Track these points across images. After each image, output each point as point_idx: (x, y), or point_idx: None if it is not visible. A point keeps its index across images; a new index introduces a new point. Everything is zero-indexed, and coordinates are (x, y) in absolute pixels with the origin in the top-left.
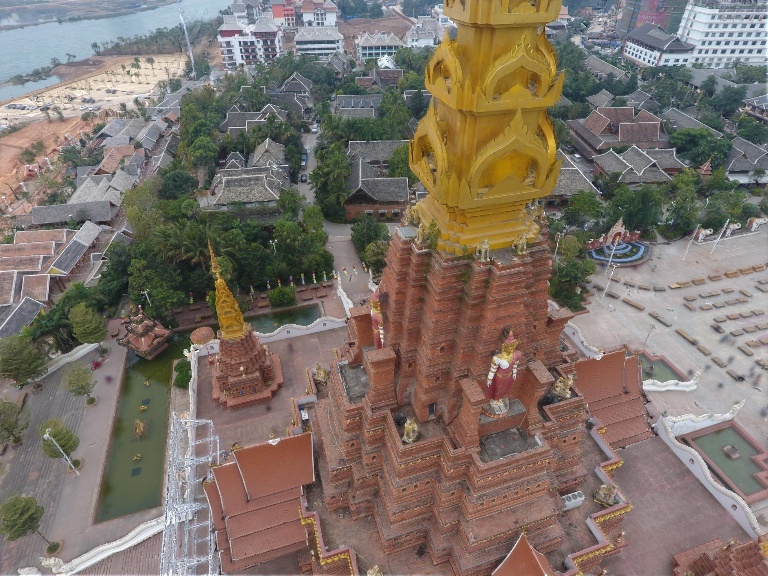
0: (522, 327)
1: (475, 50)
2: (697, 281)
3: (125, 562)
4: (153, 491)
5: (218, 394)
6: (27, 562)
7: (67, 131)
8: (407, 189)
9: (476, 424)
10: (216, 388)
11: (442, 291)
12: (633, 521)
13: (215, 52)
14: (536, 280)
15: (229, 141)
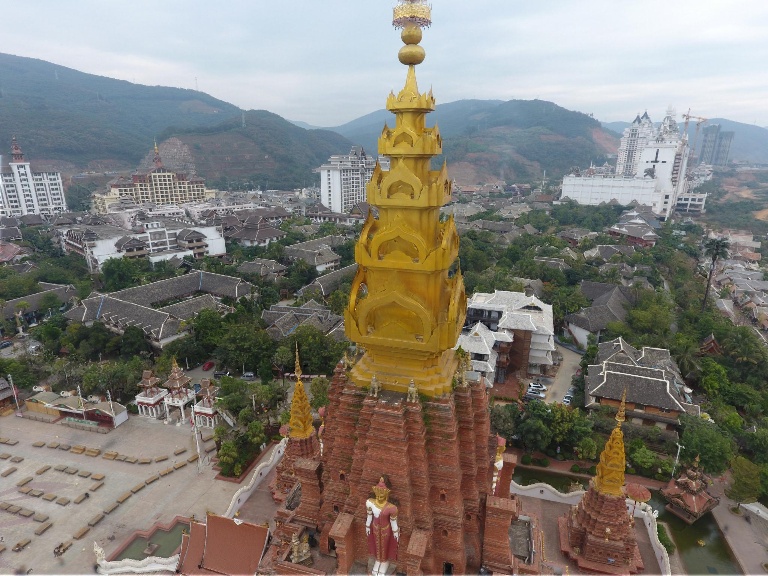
0: None
1: None
2: None
3: None
4: None
5: None
6: None
7: None
8: None
9: None
10: None
11: None
12: None
13: None
14: None
15: None
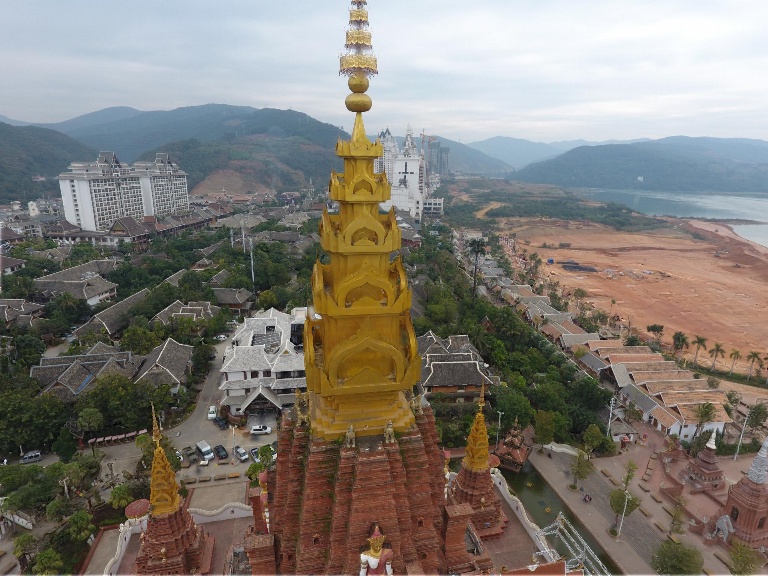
0: None
1: None
2: None
3: None
4: None
5: None
6: None
7: None
8: None
9: None
10: None
11: None
12: None
13: None
14: None
15: None
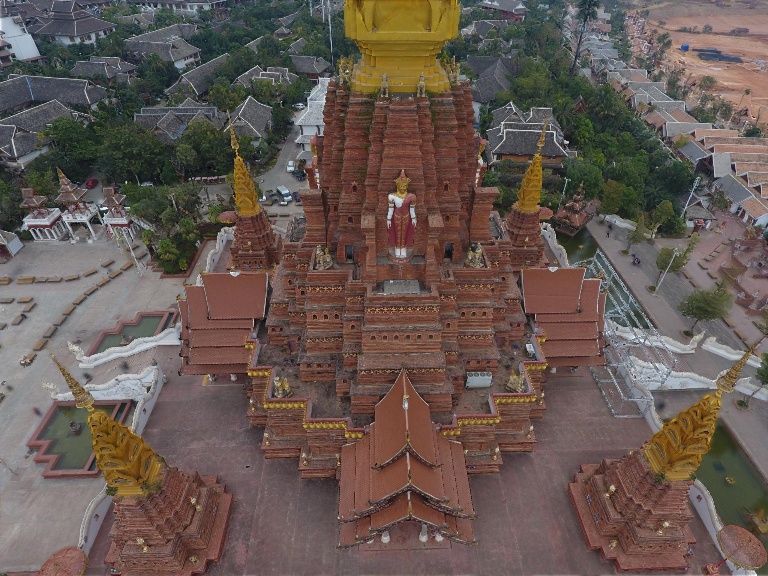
0: None
1: None
2: None
3: None
4: None
5: None
6: (762, 411)
7: None
8: None
9: None
10: None
11: None
12: None
13: None
14: None
15: None
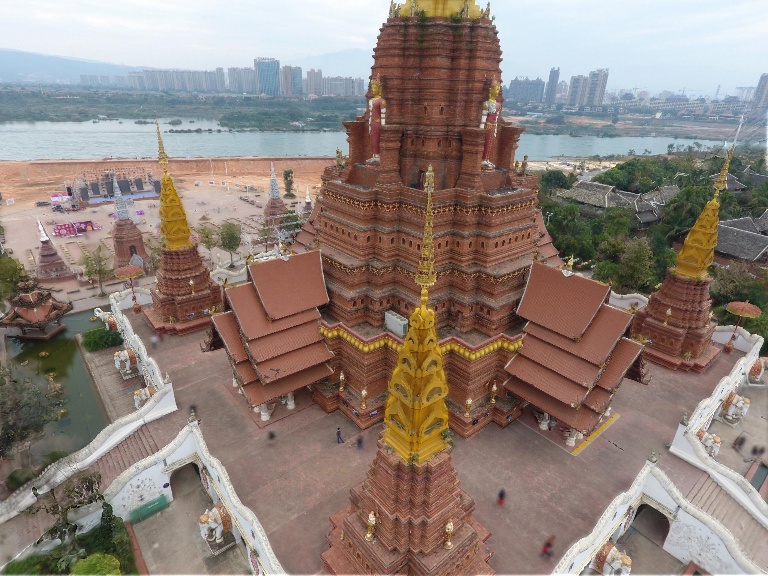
0: (395, 82)
1: None
2: None
3: None
4: None
5: None
6: None
7: (567, 173)
8: (763, 249)
9: (351, 159)
10: None
11: (375, 48)
12: (460, 456)
13: (760, 152)
14: (427, 54)
15: (644, 183)
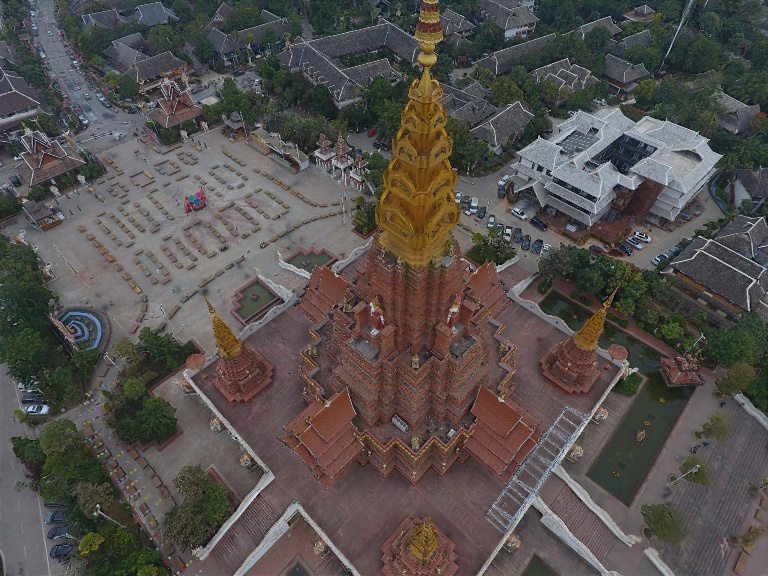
0: None
1: (440, 165)
2: (128, 277)
3: (576, 529)
4: (532, 575)
5: (452, 566)
6: None
7: None
8: None
9: None
10: (448, 575)
11: None
12: None
13: None
14: None
15: None
